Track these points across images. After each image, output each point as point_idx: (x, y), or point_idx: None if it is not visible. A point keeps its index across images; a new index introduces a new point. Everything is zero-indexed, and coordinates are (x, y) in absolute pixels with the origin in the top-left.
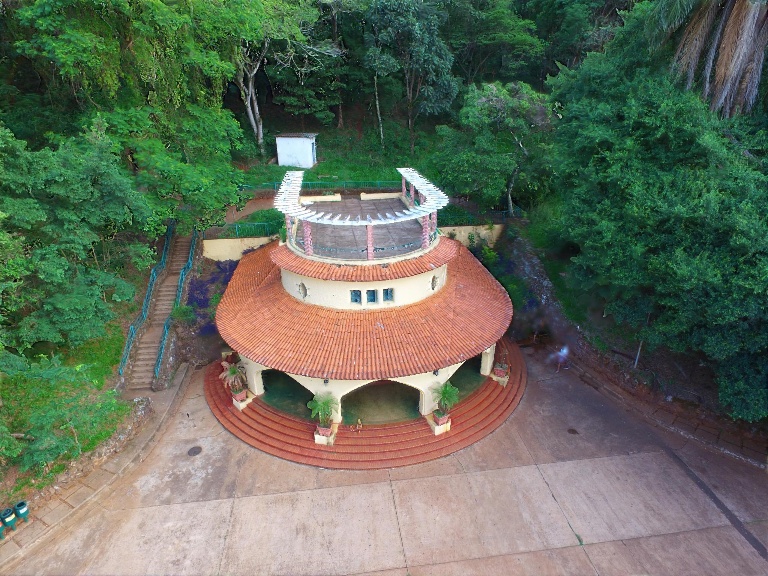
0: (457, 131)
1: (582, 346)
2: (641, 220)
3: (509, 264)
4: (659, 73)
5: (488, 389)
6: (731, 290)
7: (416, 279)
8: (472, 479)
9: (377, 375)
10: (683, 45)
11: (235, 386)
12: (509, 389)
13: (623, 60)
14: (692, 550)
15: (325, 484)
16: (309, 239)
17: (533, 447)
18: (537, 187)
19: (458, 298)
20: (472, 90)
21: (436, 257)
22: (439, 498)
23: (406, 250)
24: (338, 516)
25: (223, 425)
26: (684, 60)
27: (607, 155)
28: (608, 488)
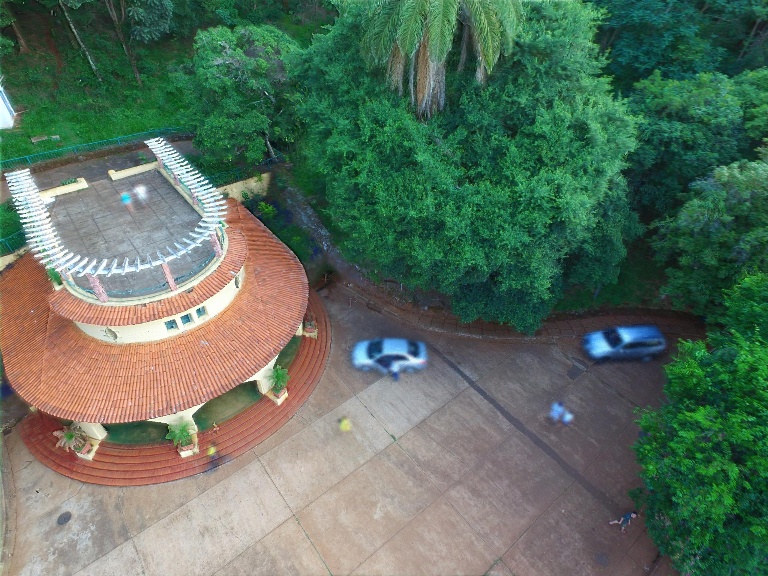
0: (194, 78)
1: (363, 281)
2: (388, 215)
3: (287, 214)
4: (377, 81)
5: (305, 347)
6: (449, 263)
7: (222, 289)
8: (316, 427)
9: (221, 391)
10: (391, 66)
11: (76, 445)
12: (320, 339)
13: (347, 63)
14: (453, 413)
15: (206, 486)
16: (99, 288)
17: (350, 382)
18: (293, 140)
19: (261, 285)
20: (199, 38)
21: (232, 261)
22: (298, 454)
23: (200, 259)
24: (229, 506)
25: (79, 480)
26: (394, 77)
27: (354, 165)
28: (402, 392)
